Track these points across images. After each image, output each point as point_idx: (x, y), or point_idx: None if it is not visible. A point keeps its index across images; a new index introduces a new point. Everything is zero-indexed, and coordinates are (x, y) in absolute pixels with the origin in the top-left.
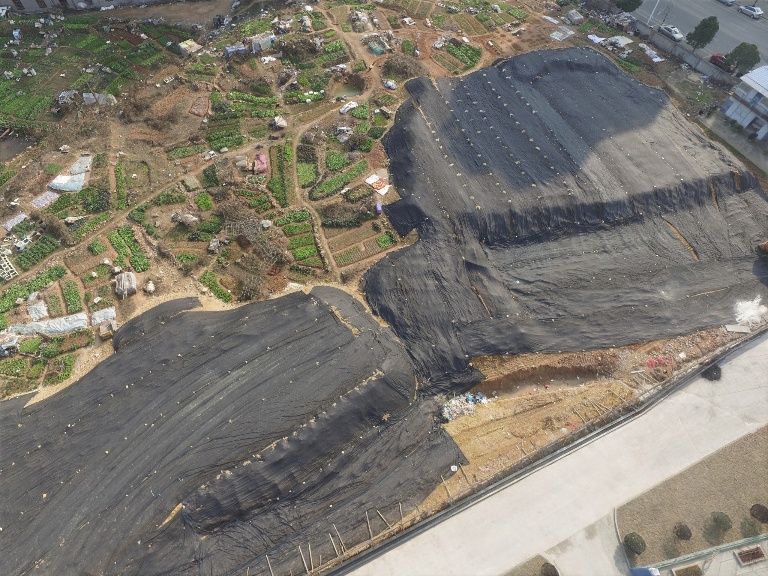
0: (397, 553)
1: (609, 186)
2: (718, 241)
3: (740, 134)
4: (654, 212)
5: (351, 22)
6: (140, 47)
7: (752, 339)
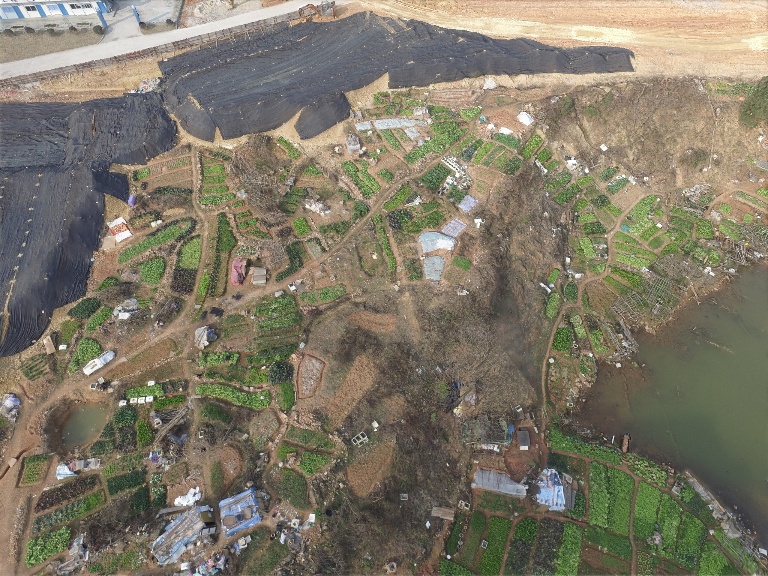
0: None
1: None
2: None
3: None
4: None
5: None
6: None
7: None
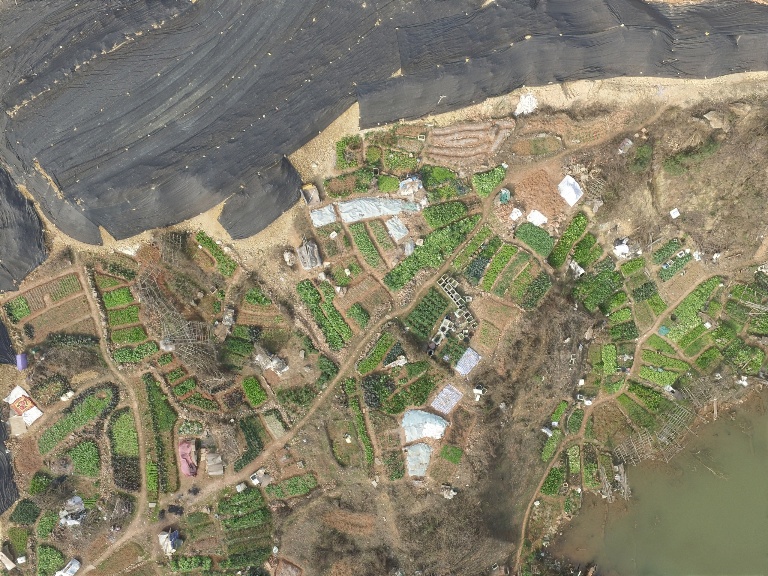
0: None
1: None
2: None
3: None
4: None
5: None
6: None
7: None
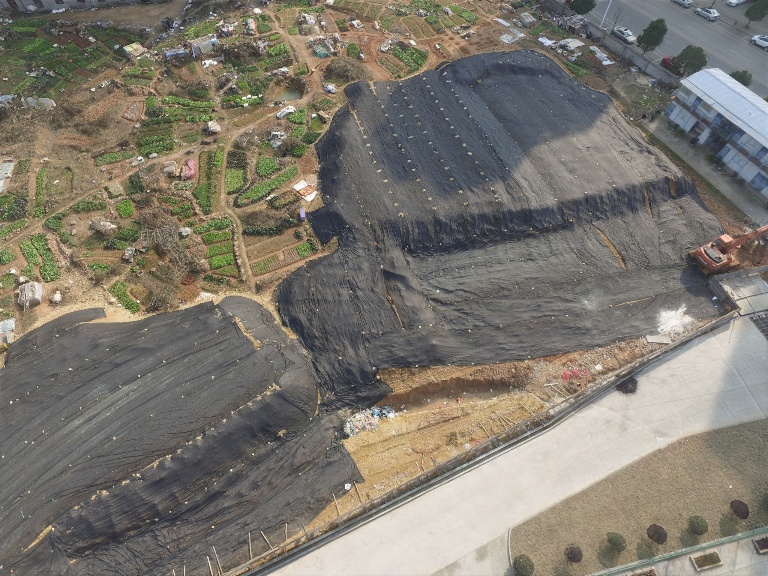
0: None
1: (539, 192)
2: (648, 249)
3: (682, 138)
4: (585, 219)
5: (298, 25)
6: (87, 50)
7: (672, 350)
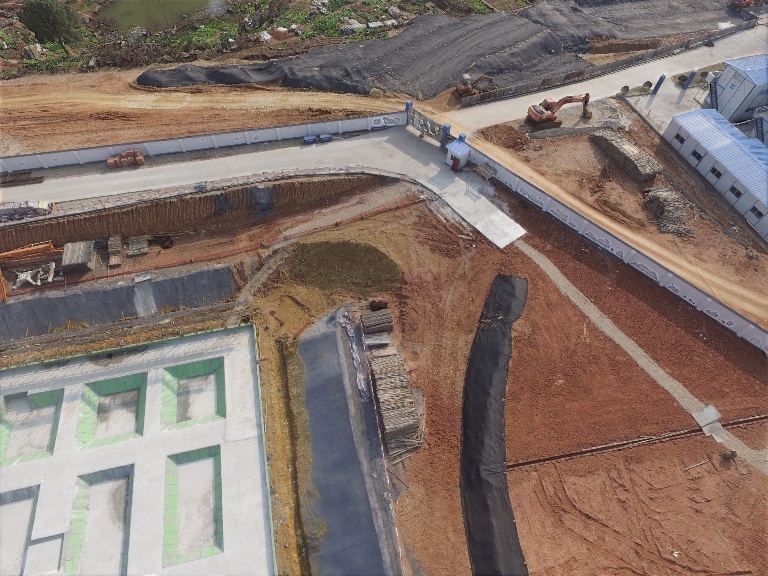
0: (575, 85)
1: None
2: (705, 4)
3: None
4: None
5: None
6: None
7: (728, 35)
